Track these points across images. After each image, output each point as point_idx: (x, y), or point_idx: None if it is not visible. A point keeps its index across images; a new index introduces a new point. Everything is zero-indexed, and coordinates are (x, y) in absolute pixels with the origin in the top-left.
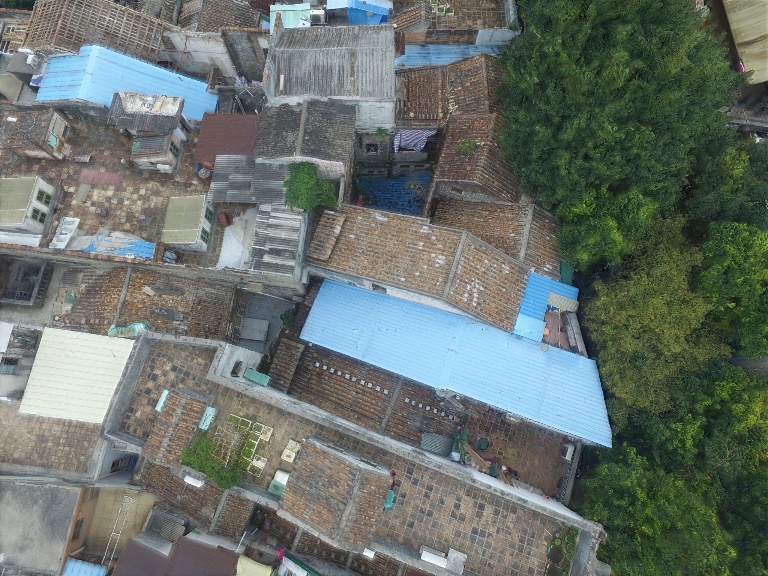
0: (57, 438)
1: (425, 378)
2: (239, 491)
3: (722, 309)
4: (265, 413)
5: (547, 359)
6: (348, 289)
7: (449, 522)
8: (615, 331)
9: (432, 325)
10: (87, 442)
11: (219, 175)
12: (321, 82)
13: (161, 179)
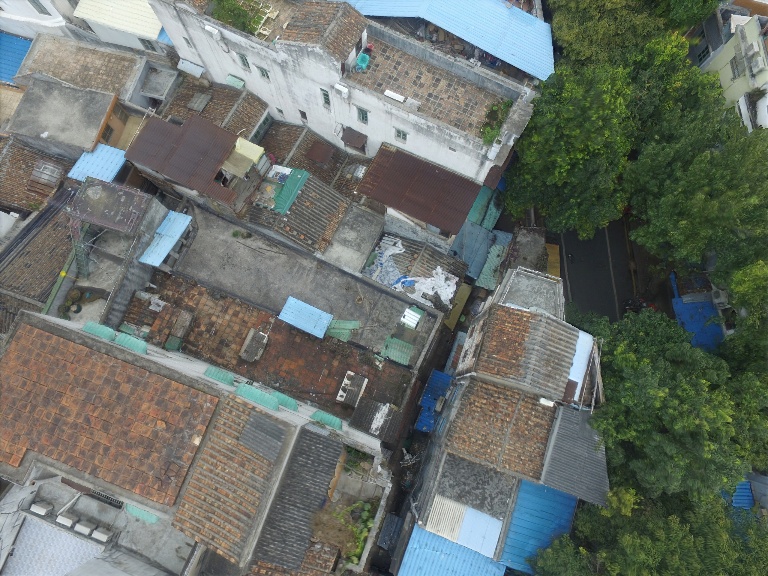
0: (97, 69)
1: (407, 13)
2: (247, 36)
3: None
4: (274, 1)
5: (510, 14)
6: None
7: (410, 87)
8: None
9: None
10: (122, 75)
11: None
12: None
13: None
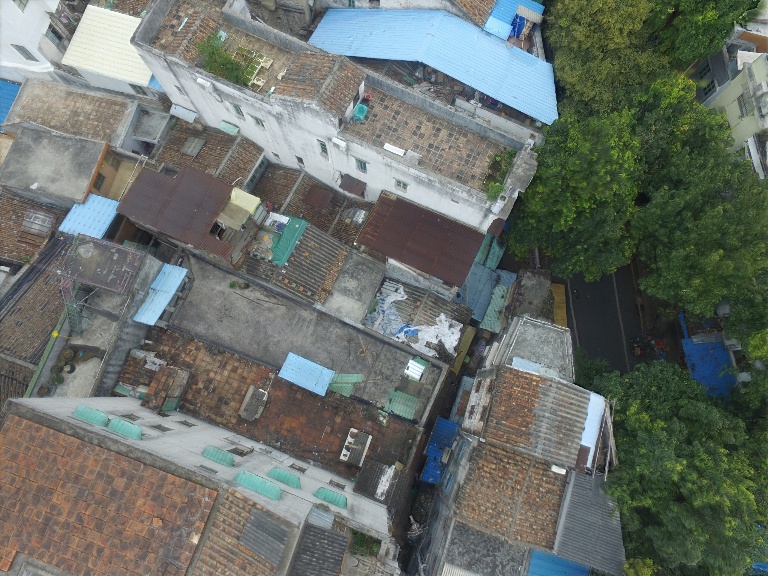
0: (88, 115)
1: (404, 56)
2: (241, 89)
3: (663, 17)
4: (267, 50)
5: (510, 55)
6: (348, 12)
7: (410, 138)
8: (569, 22)
9: (415, 22)
10: (113, 120)
11: None
12: None
13: None
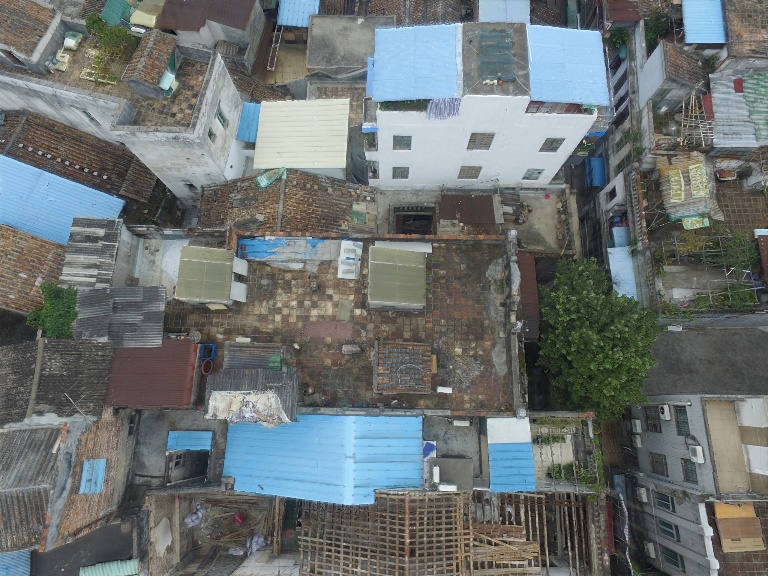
0: None
1: None
2: None
3: None
4: (87, 89)
5: None
6: None
7: None
8: None
9: None
10: None
11: (155, 320)
12: (7, 449)
13: (259, 336)
